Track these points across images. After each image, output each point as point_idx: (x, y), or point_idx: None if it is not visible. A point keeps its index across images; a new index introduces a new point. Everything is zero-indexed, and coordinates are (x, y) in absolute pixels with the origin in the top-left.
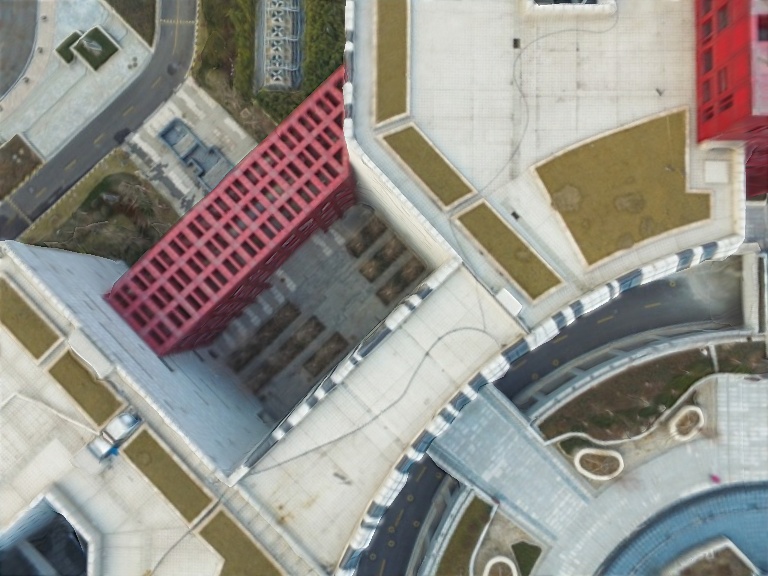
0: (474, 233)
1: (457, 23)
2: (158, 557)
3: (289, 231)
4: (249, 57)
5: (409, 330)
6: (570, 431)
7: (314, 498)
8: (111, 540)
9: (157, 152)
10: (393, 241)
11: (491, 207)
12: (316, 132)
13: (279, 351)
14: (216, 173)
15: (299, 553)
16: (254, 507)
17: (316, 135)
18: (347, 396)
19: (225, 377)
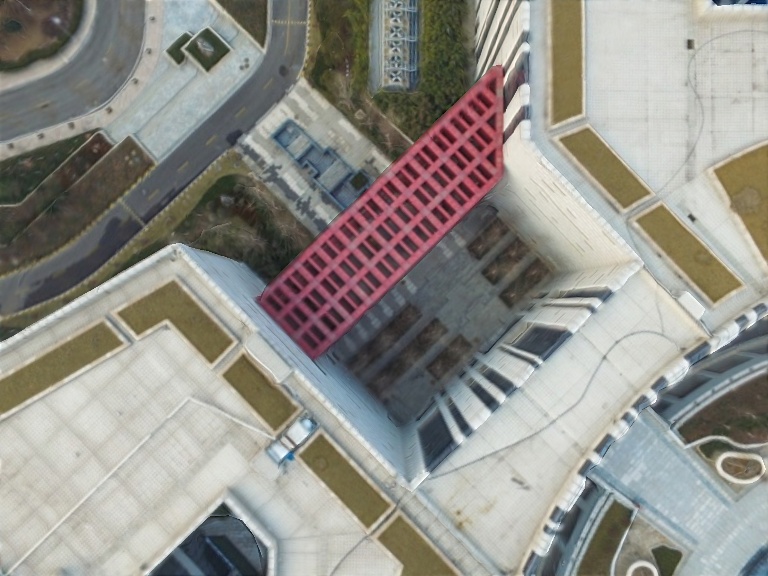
0: (653, 235)
1: (630, 24)
2: (334, 563)
3: (443, 233)
4: (366, 58)
5: (586, 333)
6: (710, 434)
7: (492, 503)
8: (287, 546)
9: (270, 153)
10: (516, 243)
11: (669, 209)
12: (469, 134)
13: (402, 354)
14: (332, 175)
15: (480, 559)
16: (432, 512)
17: (469, 137)
18: (524, 400)
19: (354, 380)
